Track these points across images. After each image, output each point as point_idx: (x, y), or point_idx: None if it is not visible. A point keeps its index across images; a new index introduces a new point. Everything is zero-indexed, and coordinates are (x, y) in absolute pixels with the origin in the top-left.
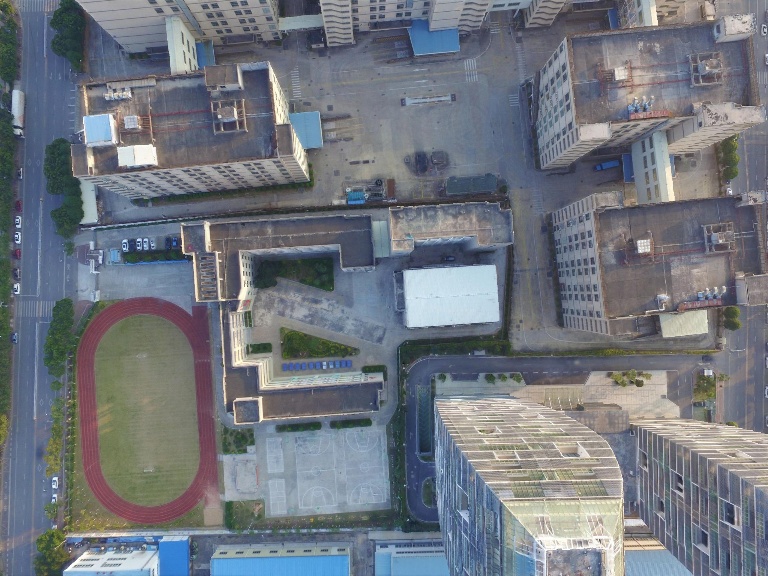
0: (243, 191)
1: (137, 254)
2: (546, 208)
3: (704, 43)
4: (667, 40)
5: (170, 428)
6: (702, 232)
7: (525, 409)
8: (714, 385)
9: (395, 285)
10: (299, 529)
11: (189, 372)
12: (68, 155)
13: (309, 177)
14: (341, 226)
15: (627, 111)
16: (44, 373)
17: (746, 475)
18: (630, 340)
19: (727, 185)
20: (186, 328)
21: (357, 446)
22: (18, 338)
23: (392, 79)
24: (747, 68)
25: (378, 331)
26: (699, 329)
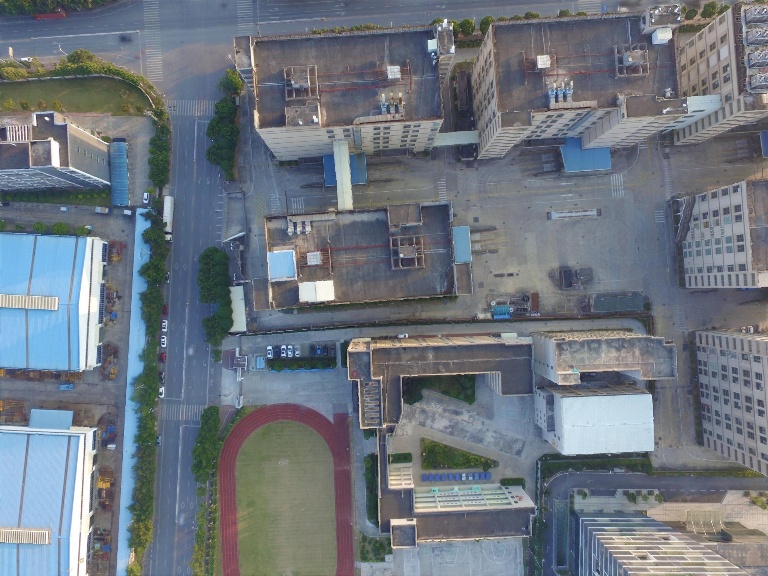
0: (388, 301)
1: (281, 361)
2: (688, 326)
3: None
4: None
5: (309, 534)
6: None
7: (705, 563)
8: None
9: (545, 407)
10: None
11: (329, 479)
12: (222, 266)
13: None
14: (501, 353)
15: None
16: (186, 476)
17: None
18: None
19: None
20: (327, 435)
21: (493, 557)
22: (161, 441)
23: (538, 192)
24: None
25: (517, 444)
26: None
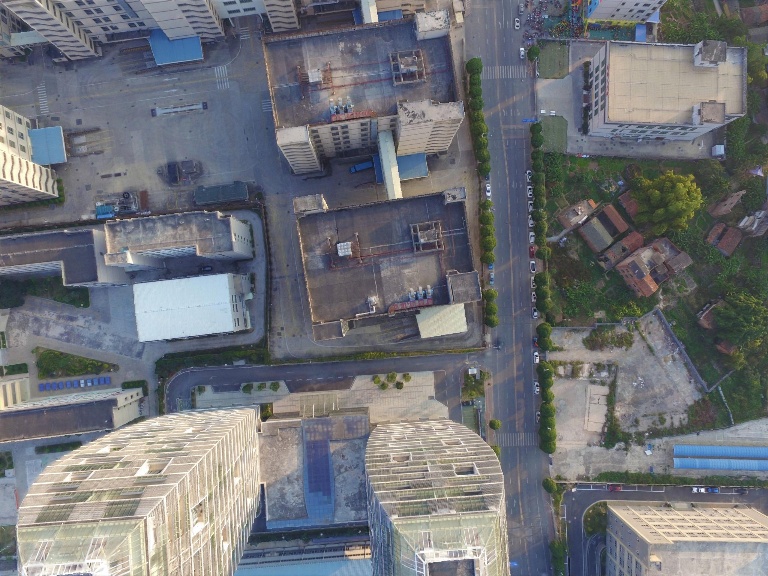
0: None
1: None
2: None
3: (406, 41)
4: (369, 40)
5: None
6: (410, 232)
7: None
8: (482, 383)
9: None
10: None
11: None
12: None
13: (58, 193)
14: (64, 242)
15: (330, 113)
16: None
17: (378, 481)
18: (395, 342)
19: (486, 181)
20: None
21: None
22: None
23: (141, 90)
24: (450, 64)
25: (137, 346)
26: (458, 328)
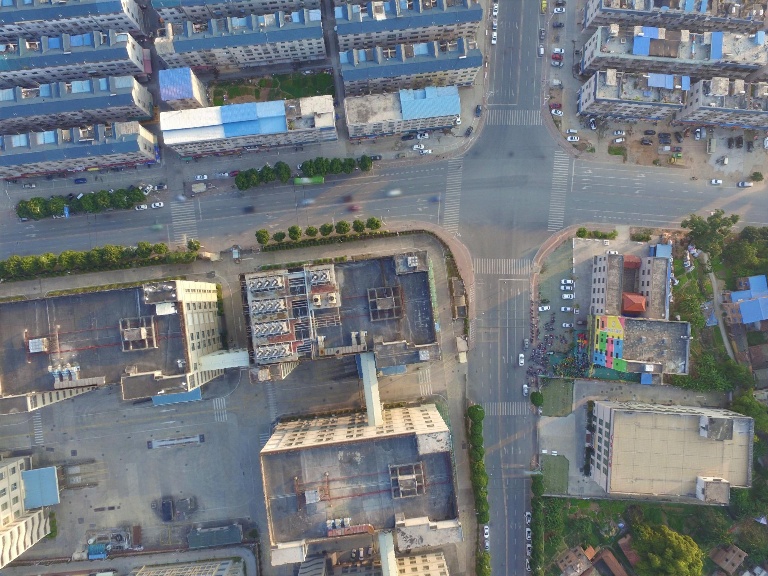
0: None
1: None
2: None
3: (407, 450)
4: (368, 448)
5: None
6: None
7: None
8: None
9: None
10: None
11: None
12: None
13: (50, 529)
14: None
15: None
16: None
17: None
18: None
19: None
20: None
21: None
22: None
23: (138, 421)
24: (451, 476)
25: None
26: None
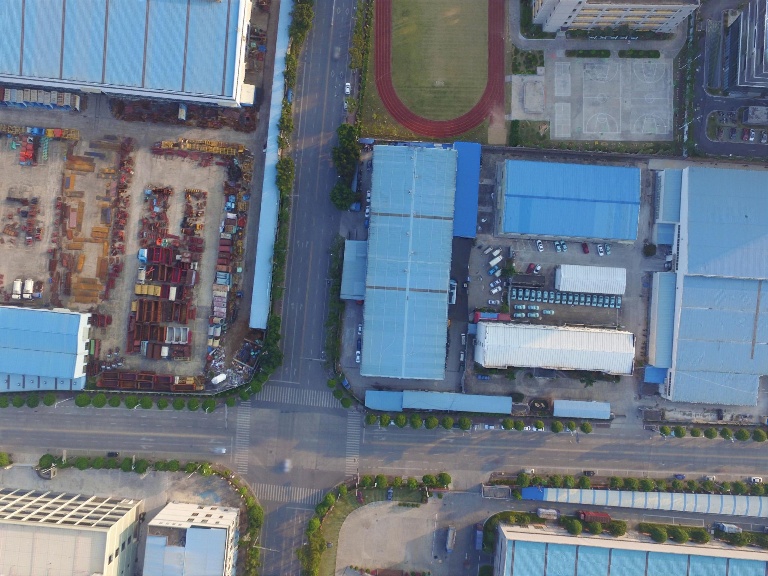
0: None
1: None
2: None
3: None
4: None
5: (461, 46)
6: None
7: None
8: None
9: None
10: (584, 150)
11: None
12: None
13: None
14: None
15: None
16: None
17: None
18: None
19: None
20: None
21: (644, 77)
22: None
23: None
24: None
25: None
26: None
